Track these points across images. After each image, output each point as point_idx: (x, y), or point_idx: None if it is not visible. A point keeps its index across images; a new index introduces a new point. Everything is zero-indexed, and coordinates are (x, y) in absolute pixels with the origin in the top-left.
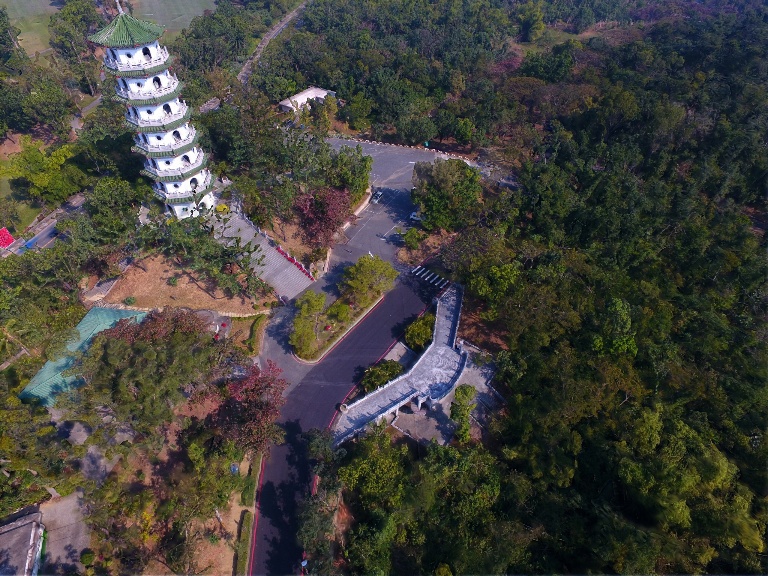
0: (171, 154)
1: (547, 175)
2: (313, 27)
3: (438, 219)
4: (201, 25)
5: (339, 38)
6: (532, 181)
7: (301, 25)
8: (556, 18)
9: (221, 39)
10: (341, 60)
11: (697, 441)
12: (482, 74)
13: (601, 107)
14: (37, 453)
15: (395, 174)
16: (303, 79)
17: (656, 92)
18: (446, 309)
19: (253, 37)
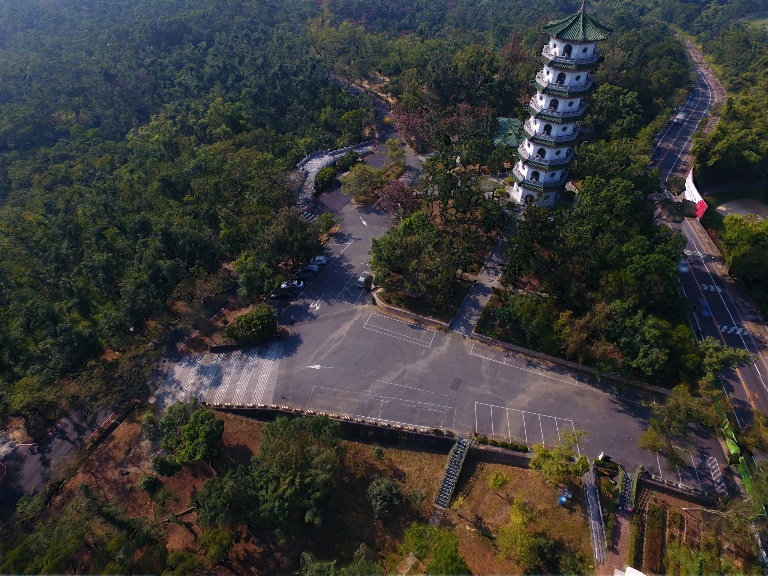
0: None
1: None
2: None
3: None
4: None
5: None
6: None
7: None
8: None
9: None
10: None
11: (197, 149)
12: None
13: None
14: (466, 73)
15: (343, 333)
16: None
17: None
18: (306, 193)
19: None
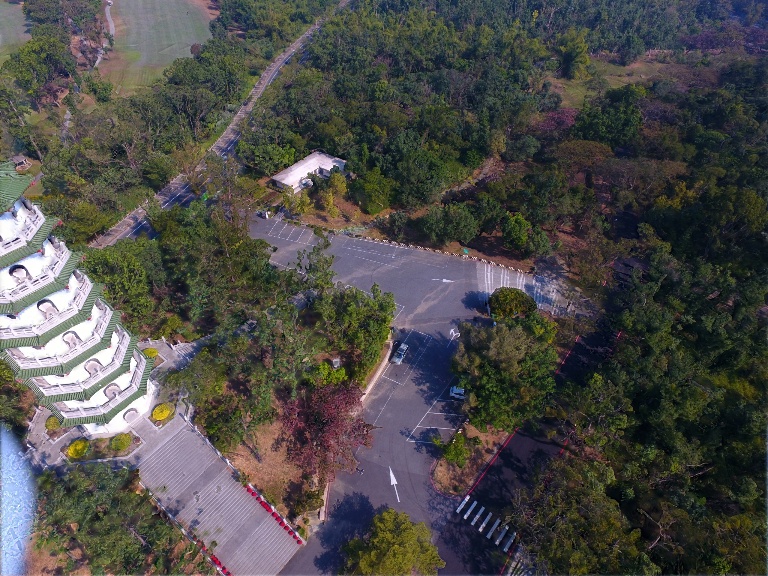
0: (58, 372)
1: (656, 336)
2: (320, 62)
3: (496, 418)
4: (182, 69)
5: (350, 82)
6: (642, 361)
7: (307, 57)
8: (600, 47)
9: (205, 89)
10: (352, 117)
11: None
12: (524, 128)
13: (699, 196)
14: None
15: (424, 303)
16: (304, 143)
17: (764, 169)
18: None
19: (250, 74)
